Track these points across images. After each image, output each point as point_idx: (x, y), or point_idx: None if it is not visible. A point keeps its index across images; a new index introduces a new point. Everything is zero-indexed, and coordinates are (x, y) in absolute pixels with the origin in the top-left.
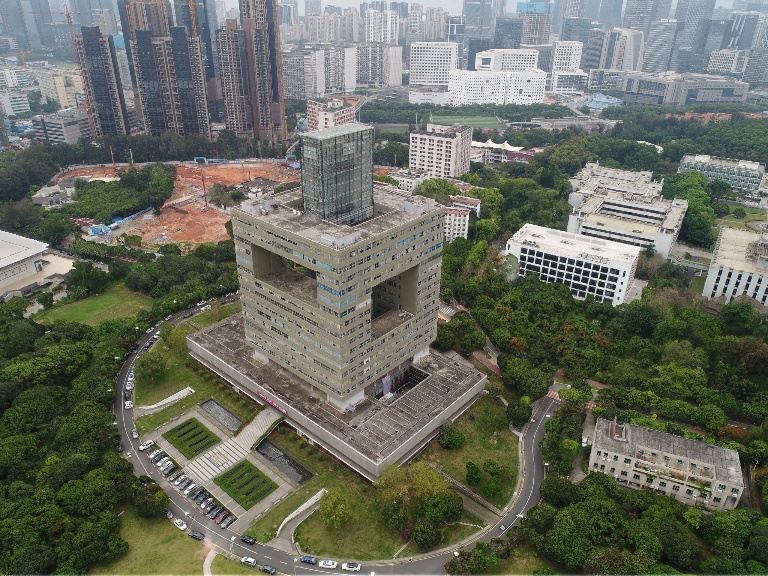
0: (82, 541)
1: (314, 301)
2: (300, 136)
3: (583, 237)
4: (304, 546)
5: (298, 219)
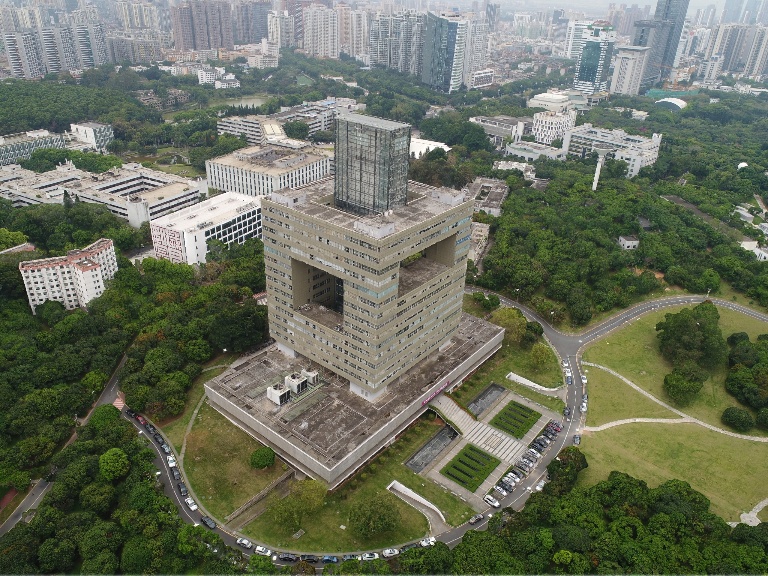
0: (638, 485)
1: (436, 270)
2: (392, 131)
3: (195, 206)
4: (559, 384)
5: (402, 214)
